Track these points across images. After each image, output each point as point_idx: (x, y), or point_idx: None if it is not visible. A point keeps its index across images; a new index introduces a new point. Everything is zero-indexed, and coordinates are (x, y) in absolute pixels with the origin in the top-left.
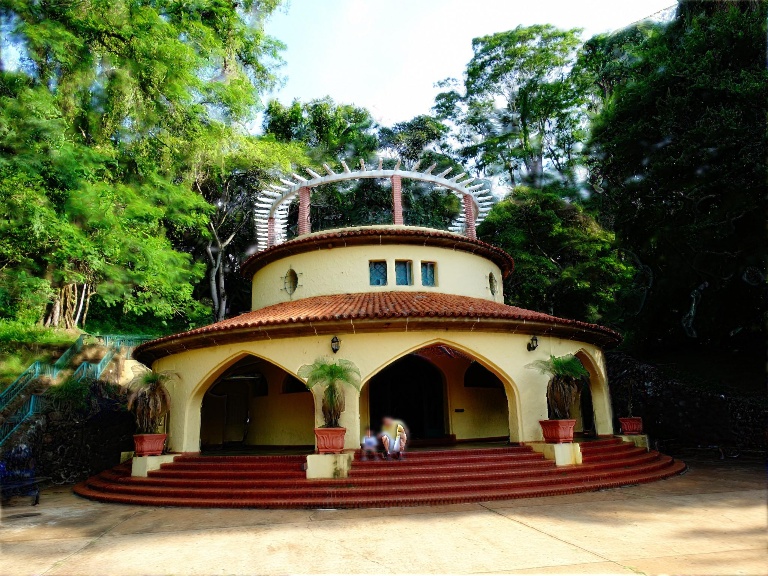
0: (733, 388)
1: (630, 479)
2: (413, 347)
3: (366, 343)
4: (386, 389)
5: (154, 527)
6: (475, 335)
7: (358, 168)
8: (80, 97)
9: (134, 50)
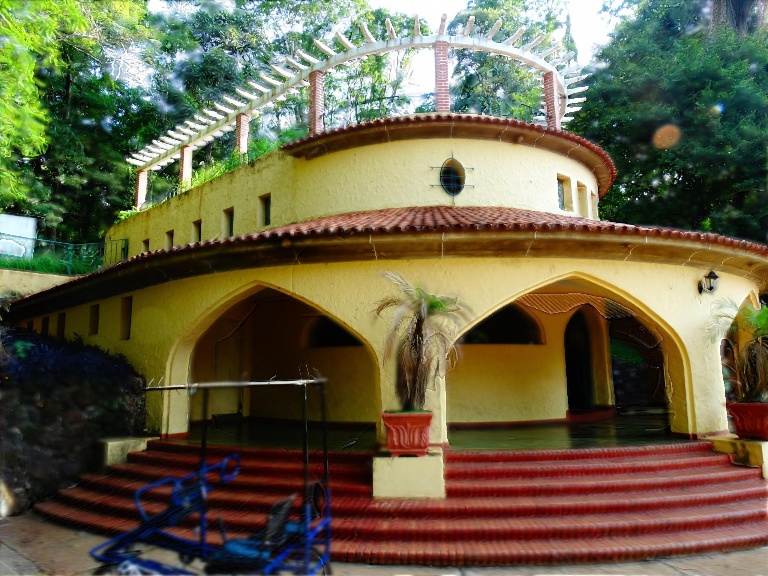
0: None
1: None
2: None
3: (723, 285)
4: None
5: None
6: None
7: (167, 50)
8: None
9: None
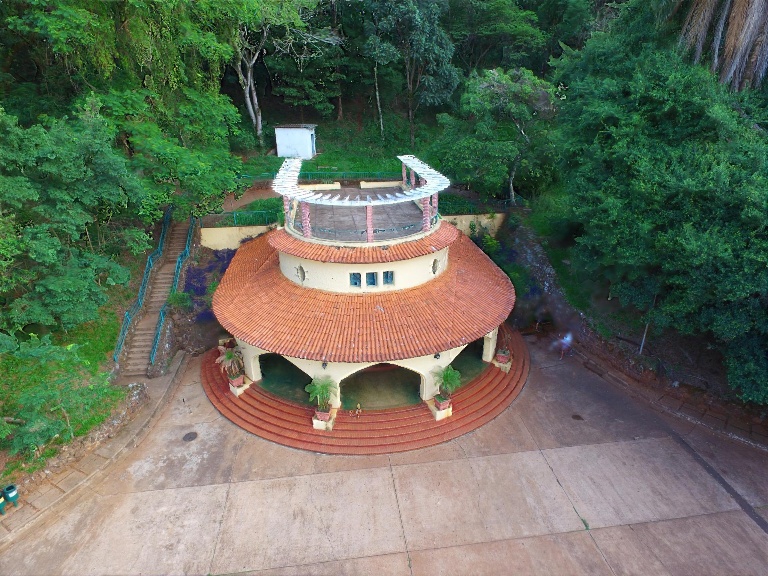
0: (593, 306)
1: (471, 429)
2: None
3: (341, 364)
4: None
5: (249, 472)
6: None
7: None
8: (109, 54)
9: None
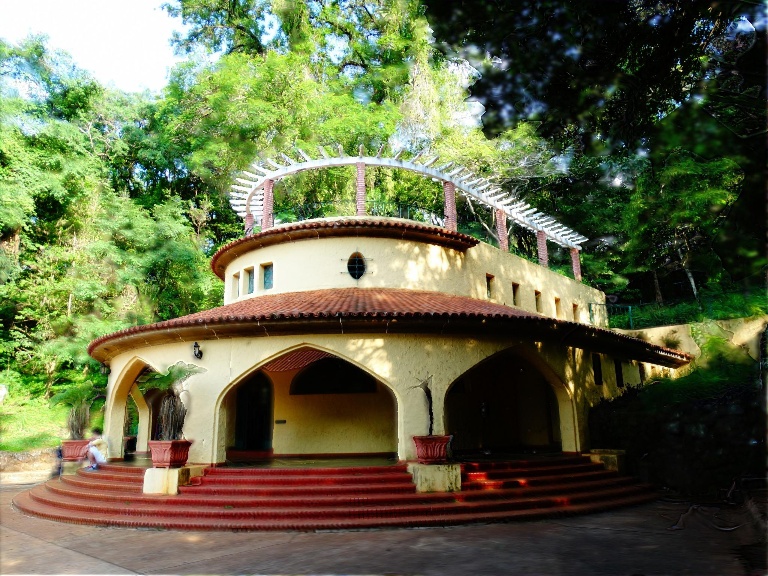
0: None
1: (159, 521)
2: (125, 366)
3: None
4: (244, 399)
5: None
6: (154, 349)
7: None
8: None
9: (282, 126)
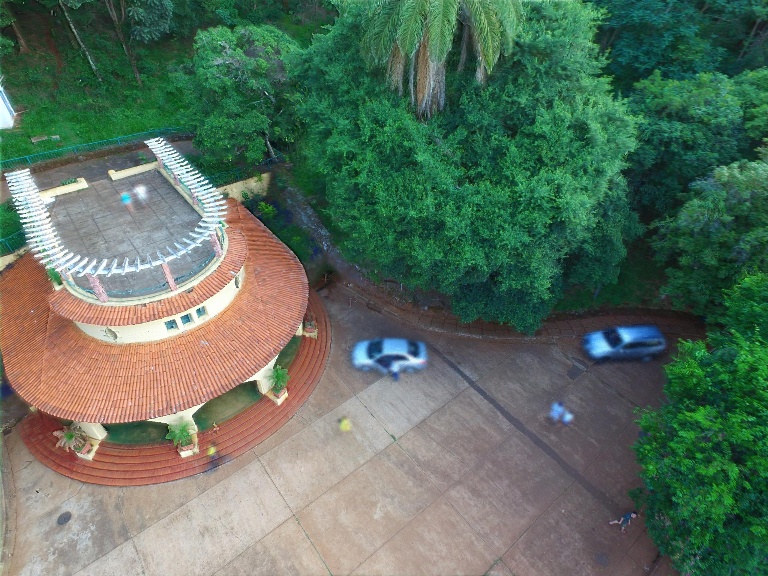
0: None
1: (305, 400)
2: None
3: None
4: None
5: (144, 521)
6: None
7: None
8: None
9: None
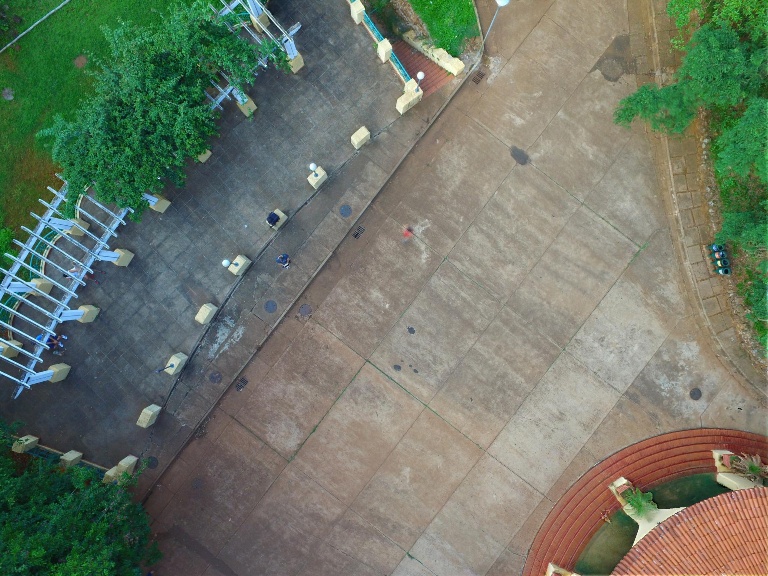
0: None
1: None
2: None
3: None
4: None
5: (621, 411)
6: None
7: None
8: None
9: None
